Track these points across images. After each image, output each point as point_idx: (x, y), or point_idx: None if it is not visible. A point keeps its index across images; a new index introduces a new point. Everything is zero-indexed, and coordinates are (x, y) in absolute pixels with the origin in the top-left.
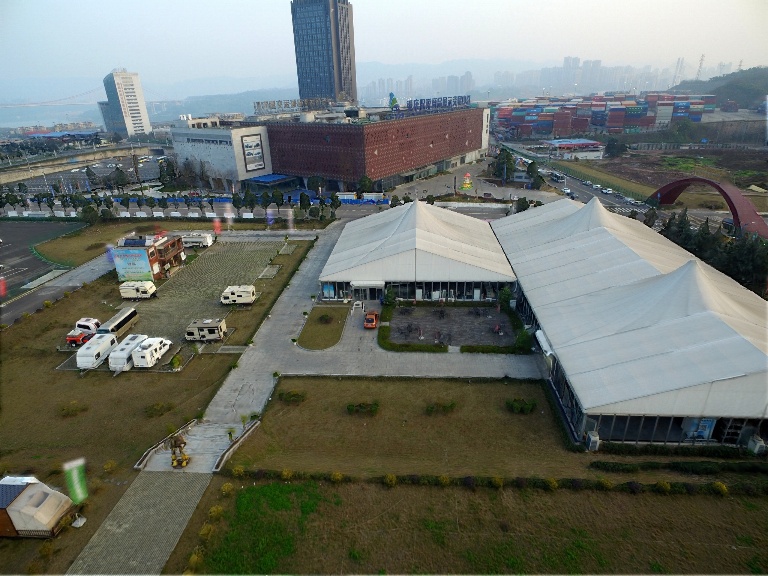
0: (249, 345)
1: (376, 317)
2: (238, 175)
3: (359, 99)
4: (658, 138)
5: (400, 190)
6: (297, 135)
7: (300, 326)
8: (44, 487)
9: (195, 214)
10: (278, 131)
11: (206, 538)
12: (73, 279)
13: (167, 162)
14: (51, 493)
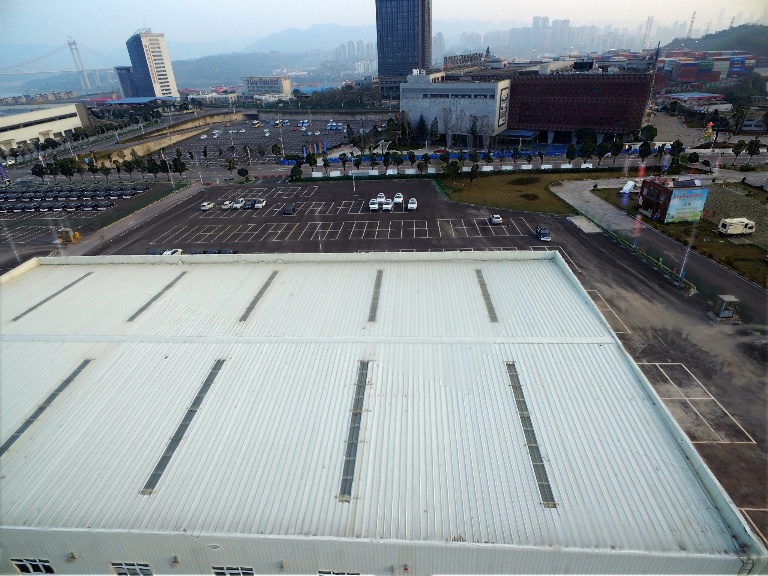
0: None
1: None
2: None
3: (434, 58)
4: (735, 92)
5: None
6: (553, 87)
7: None
8: None
9: (530, 167)
10: (526, 84)
11: None
12: (617, 223)
13: (399, 120)
14: None
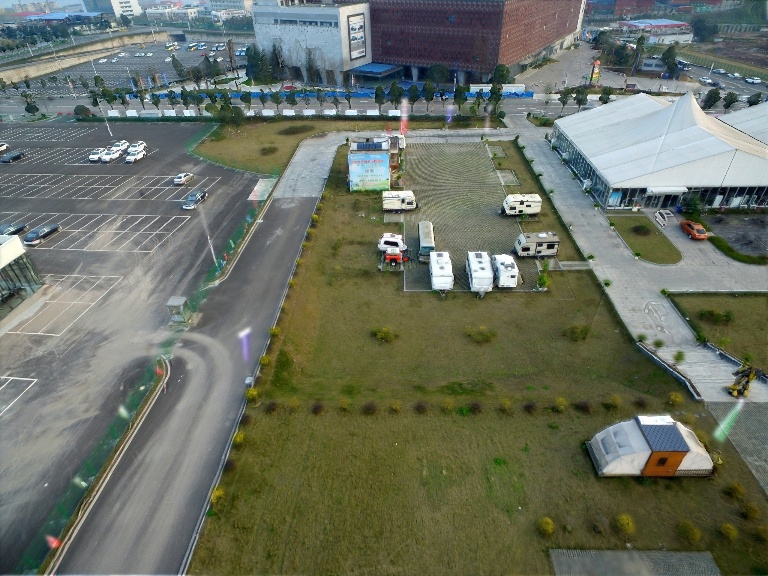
0: (589, 260)
1: None
2: (343, 64)
3: None
4: (730, 18)
5: (522, 81)
6: (410, 14)
7: (617, 238)
8: (682, 425)
9: (333, 111)
10: (385, 9)
11: None
12: (297, 189)
13: (250, 49)
14: None
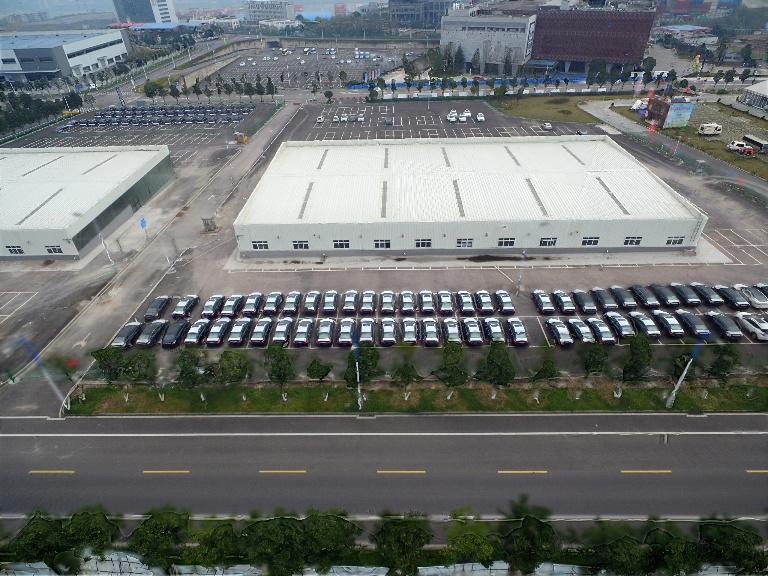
0: None
1: None
2: None
3: None
4: (723, 24)
5: None
6: (573, 22)
7: None
8: None
9: (558, 91)
10: (550, 19)
11: None
12: (631, 128)
13: (440, 50)
14: None
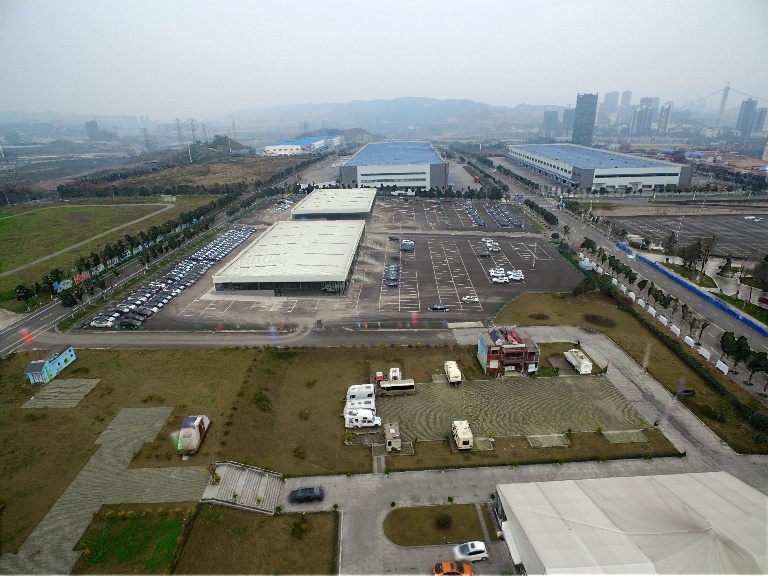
0: None
1: (453, 575)
2: None
3: None
4: None
5: None
6: None
7: (429, 502)
8: (194, 433)
9: (677, 330)
10: None
11: (147, 514)
12: (469, 336)
13: None
14: (192, 437)
